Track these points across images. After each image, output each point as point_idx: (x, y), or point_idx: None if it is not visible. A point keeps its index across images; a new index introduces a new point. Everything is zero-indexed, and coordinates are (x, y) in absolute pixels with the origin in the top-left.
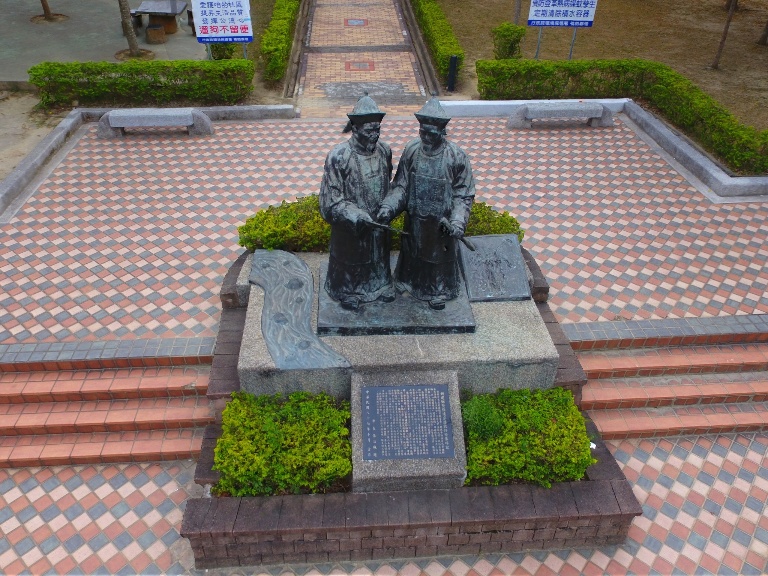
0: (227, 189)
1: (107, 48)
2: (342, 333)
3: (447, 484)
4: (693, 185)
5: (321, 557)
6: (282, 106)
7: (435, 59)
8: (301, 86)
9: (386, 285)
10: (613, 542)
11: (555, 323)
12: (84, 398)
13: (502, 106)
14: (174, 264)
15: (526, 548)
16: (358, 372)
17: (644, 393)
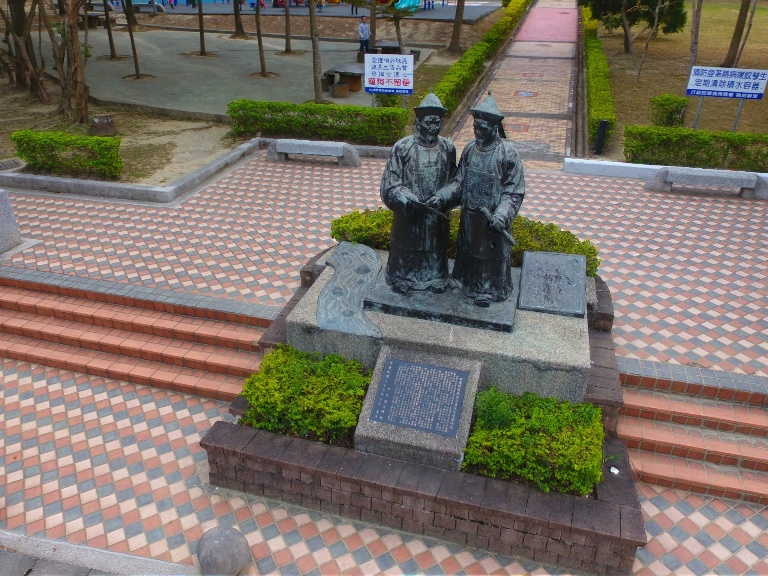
0: (351, 206)
1: (299, 98)
2: (385, 310)
3: (444, 463)
4: None
5: (314, 503)
6: None
7: None
8: (452, 139)
9: (438, 278)
10: (615, 575)
11: (611, 349)
12: (175, 336)
13: (644, 169)
14: (282, 253)
15: (516, 554)
16: (388, 345)
17: (703, 444)
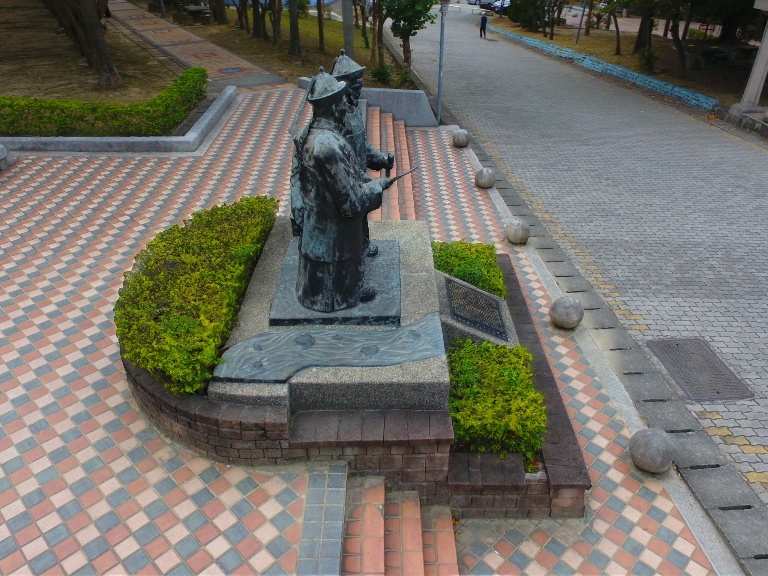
0: None
1: None
2: None
3: None
4: (167, 156)
5: None
6: None
7: None
8: None
9: None
10: None
11: None
12: None
13: None
14: (81, 562)
15: None
16: None
17: None
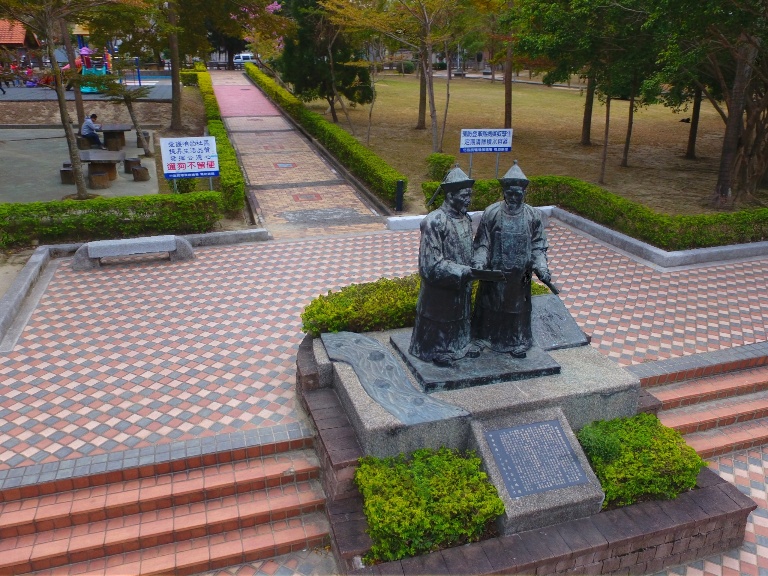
0: (236, 300)
1: (50, 194)
2: (448, 387)
3: (587, 511)
4: (639, 262)
5: None
6: (256, 230)
7: (375, 187)
8: (260, 215)
9: (469, 343)
10: (734, 545)
11: None
12: (174, 503)
13: None
14: (219, 366)
15: (665, 566)
16: (476, 419)
17: (693, 418)
